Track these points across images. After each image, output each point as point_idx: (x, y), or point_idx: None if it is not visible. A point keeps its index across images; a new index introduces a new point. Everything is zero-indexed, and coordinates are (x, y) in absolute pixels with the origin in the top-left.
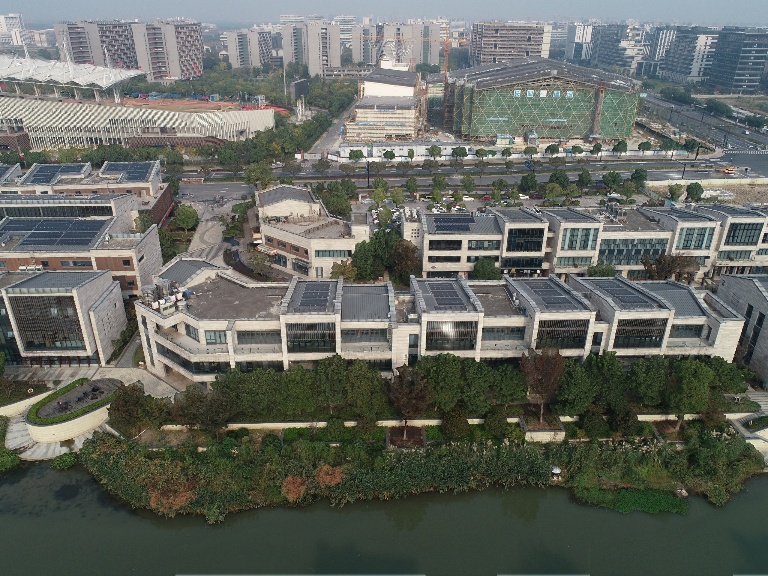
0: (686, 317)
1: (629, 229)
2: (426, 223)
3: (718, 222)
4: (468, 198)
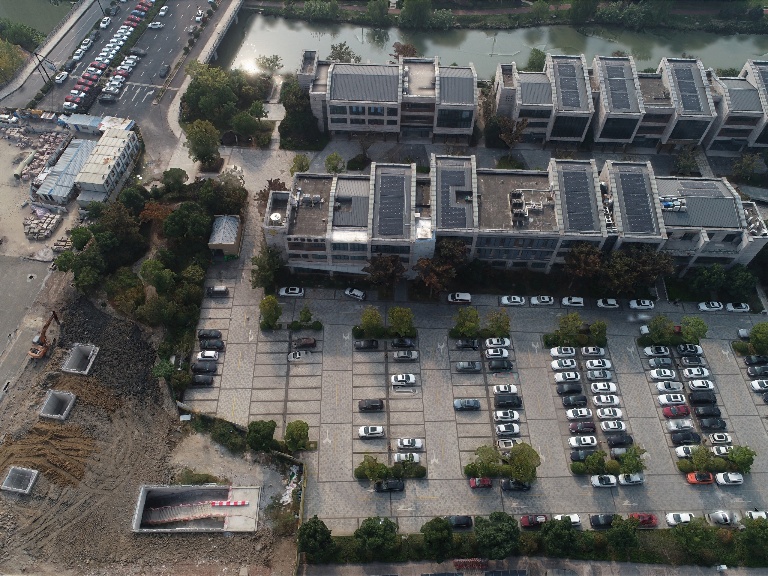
0: (530, 72)
1: (513, 182)
2: (730, 189)
3: (434, 155)
4: (680, 513)
